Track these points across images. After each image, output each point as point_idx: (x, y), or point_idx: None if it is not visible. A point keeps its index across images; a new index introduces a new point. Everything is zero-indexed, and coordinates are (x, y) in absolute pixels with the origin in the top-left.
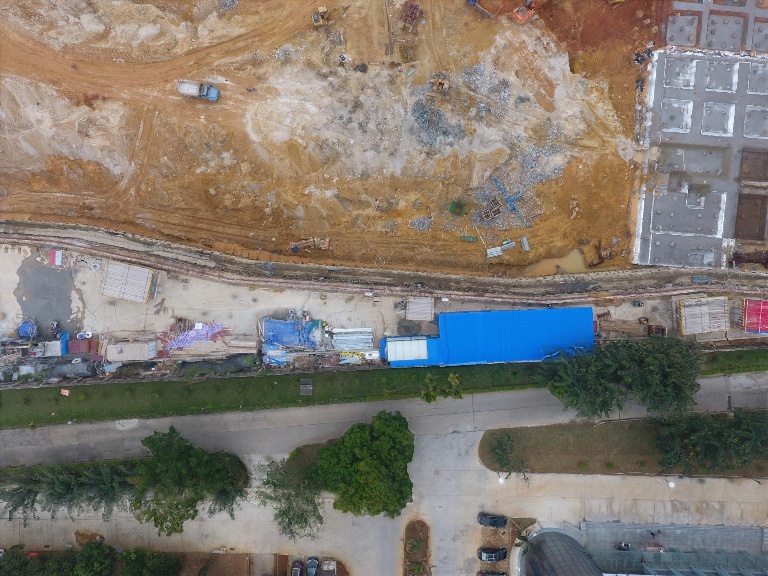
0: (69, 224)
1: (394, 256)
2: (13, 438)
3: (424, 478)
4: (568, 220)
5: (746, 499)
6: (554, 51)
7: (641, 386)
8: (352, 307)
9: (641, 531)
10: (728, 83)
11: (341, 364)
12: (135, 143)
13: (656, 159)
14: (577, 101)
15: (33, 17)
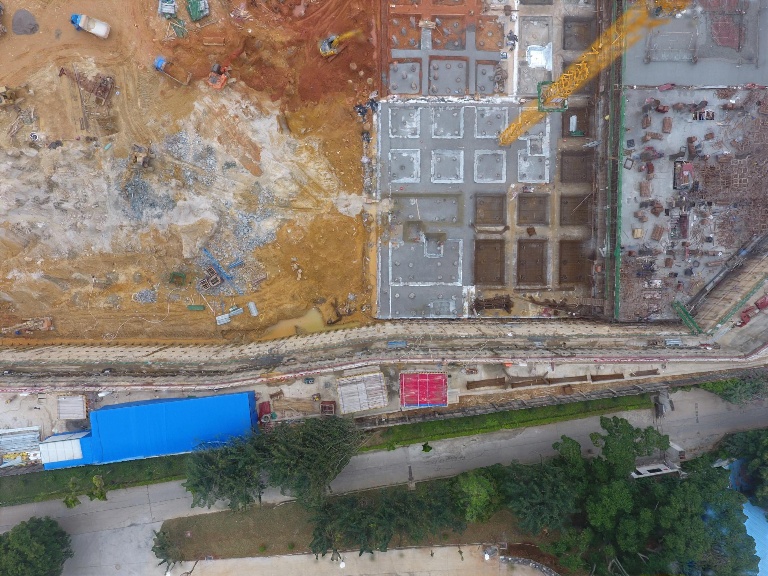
0: None
1: (122, 330)
2: None
3: (106, 573)
4: (295, 282)
5: (436, 567)
6: (256, 114)
7: None
8: (16, 406)
9: None
10: (456, 128)
11: (2, 467)
12: None
13: (388, 211)
14: (286, 163)
15: None
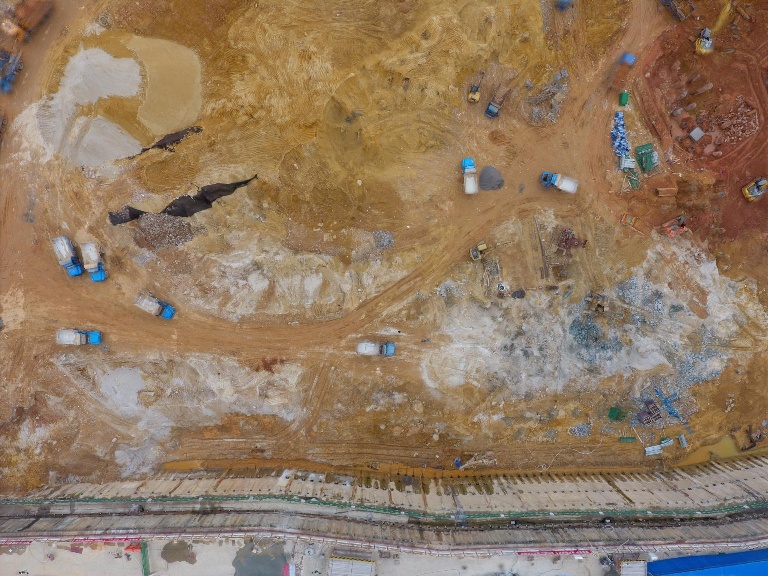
0: (264, 493)
1: (555, 462)
2: None
3: None
4: (722, 414)
5: None
6: (704, 260)
7: None
8: (559, 565)
9: None
10: None
11: None
12: (308, 393)
13: None
14: (728, 305)
15: (209, 292)
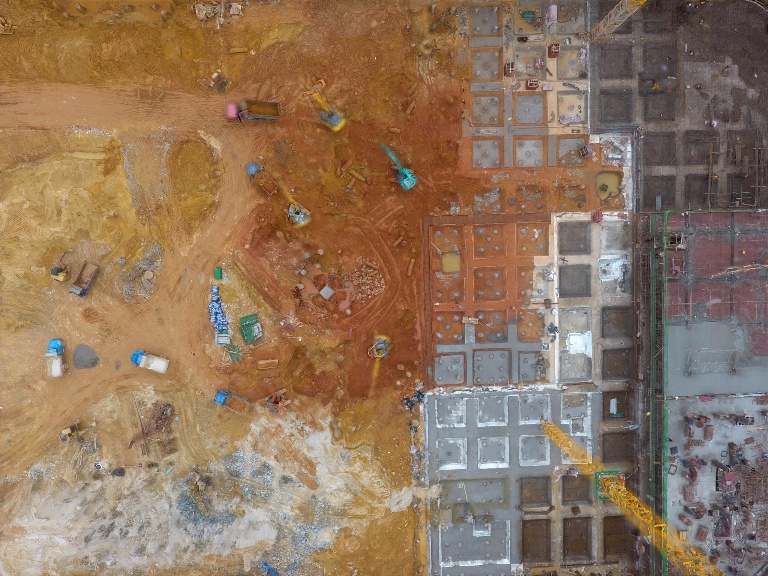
0: None
1: None
2: None
3: None
4: None
5: None
6: (310, 431)
7: None
8: None
9: None
10: (500, 415)
11: None
12: None
13: (437, 496)
14: (340, 474)
15: None
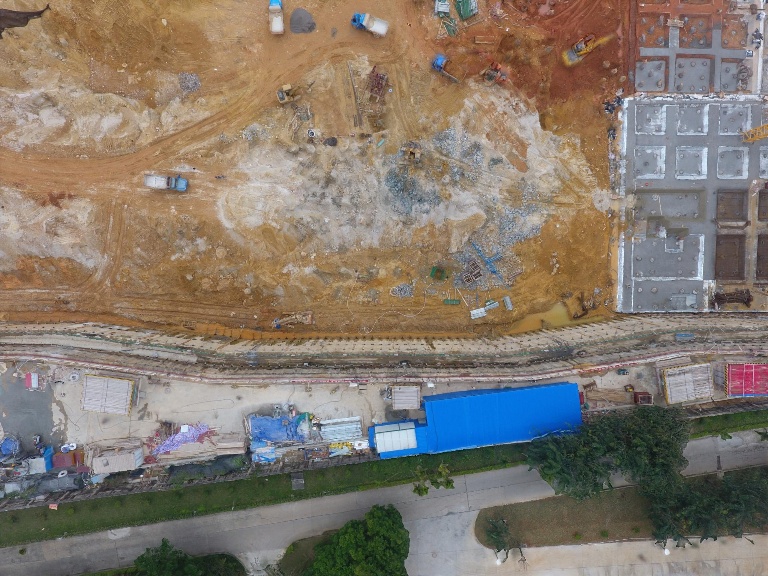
0: (44, 329)
1: (378, 324)
2: (4, 556)
3: (422, 561)
4: (549, 276)
5: (741, 555)
6: (523, 111)
7: (630, 465)
8: (338, 397)
9: None
10: (699, 125)
11: (331, 457)
12: (106, 236)
13: (633, 206)
14: (550, 159)
15: None
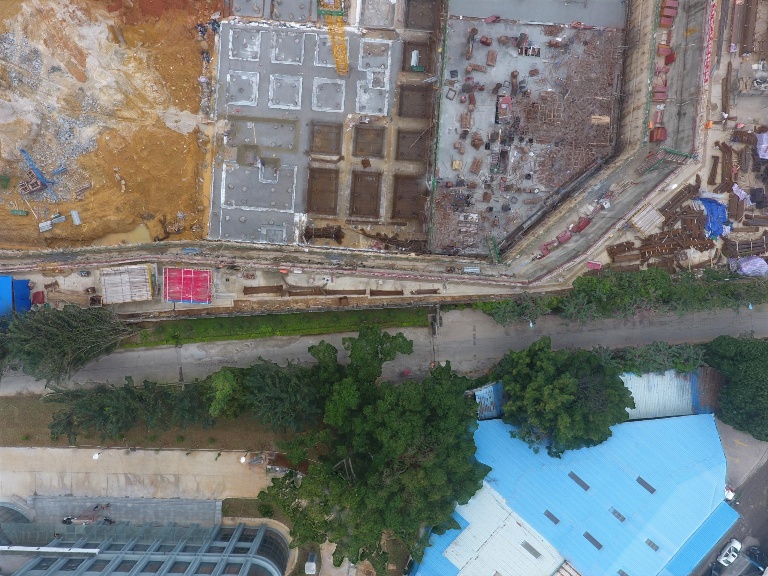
0: None
1: None
2: None
3: None
4: (120, 194)
5: (202, 472)
6: (83, 19)
7: None
8: None
9: (91, 505)
10: (297, 55)
11: None
12: None
13: (224, 132)
14: (112, 71)
15: None
